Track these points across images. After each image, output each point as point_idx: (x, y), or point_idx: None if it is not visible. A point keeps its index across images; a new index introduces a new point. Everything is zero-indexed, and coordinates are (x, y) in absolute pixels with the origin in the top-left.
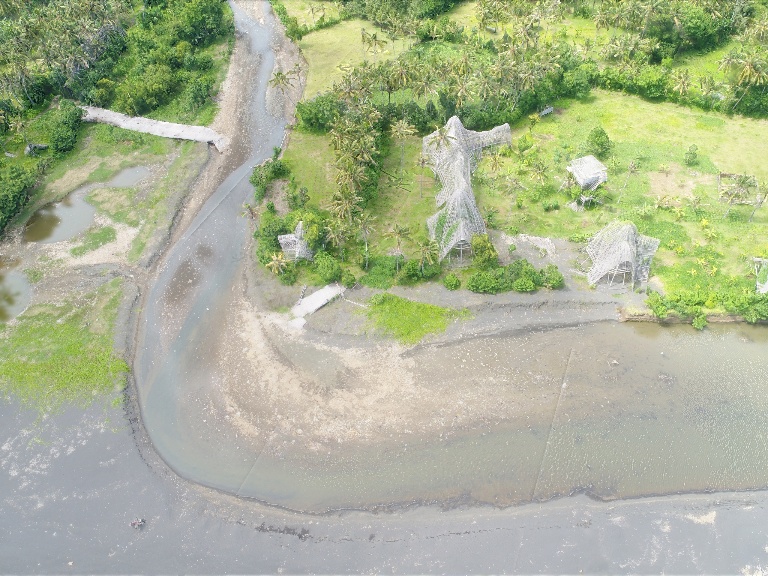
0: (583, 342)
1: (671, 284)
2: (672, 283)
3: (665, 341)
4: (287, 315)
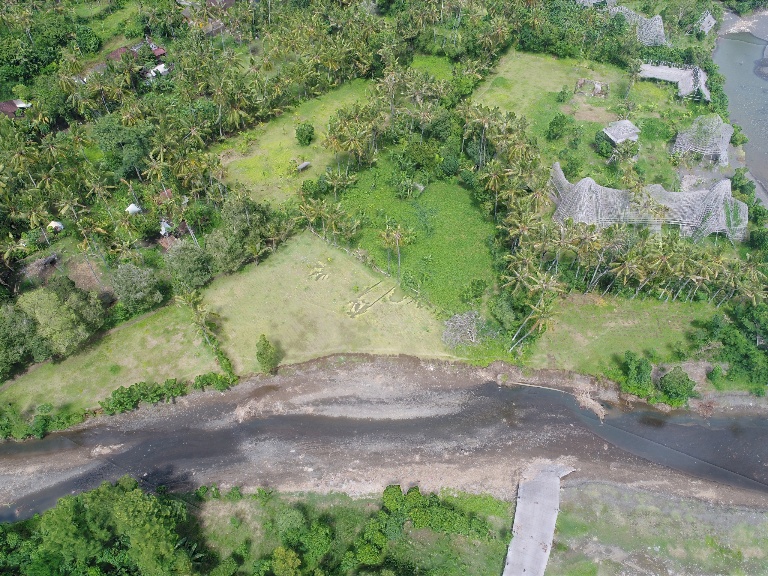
0: None
1: None
2: None
3: (754, 150)
4: None
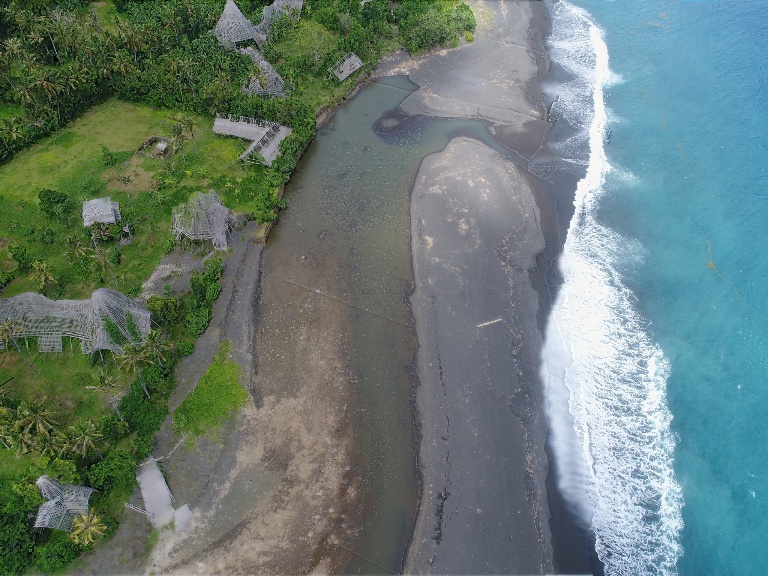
0: (279, 272)
1: (243, 207)
2: (242, 206)
3: (290, 227)
4: (163, 534)
